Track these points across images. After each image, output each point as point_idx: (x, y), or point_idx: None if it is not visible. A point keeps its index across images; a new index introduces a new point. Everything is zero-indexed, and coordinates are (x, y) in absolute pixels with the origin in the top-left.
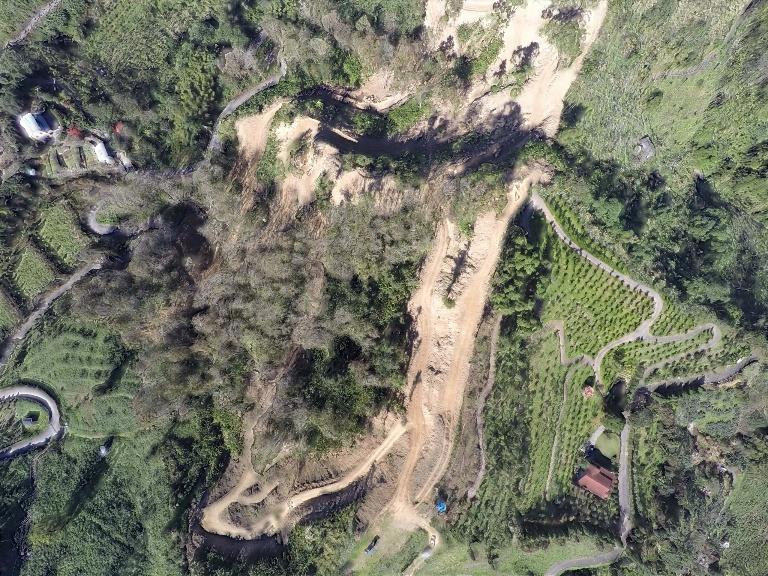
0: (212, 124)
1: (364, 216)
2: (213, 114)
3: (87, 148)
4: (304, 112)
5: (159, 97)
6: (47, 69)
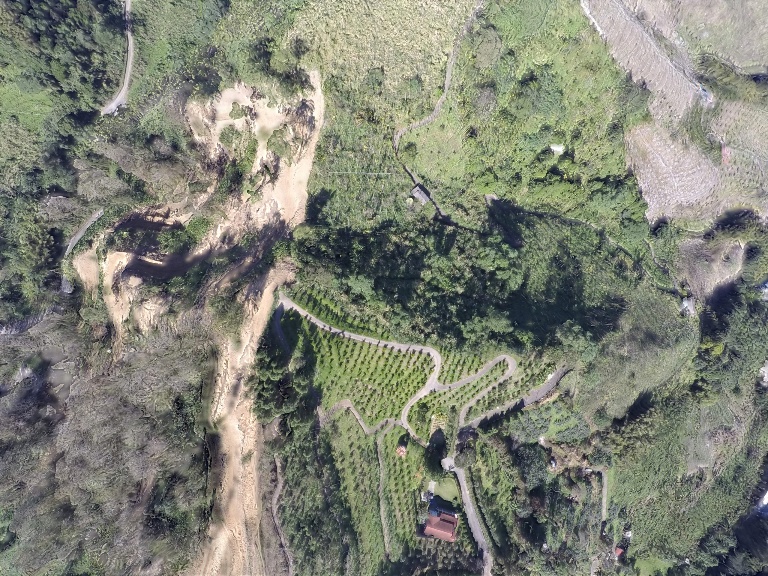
0: (59, 265)
1: (156, 347)
2: (58, 256)
3: None
4: (113, 246)
5: (6, 255)
6: None
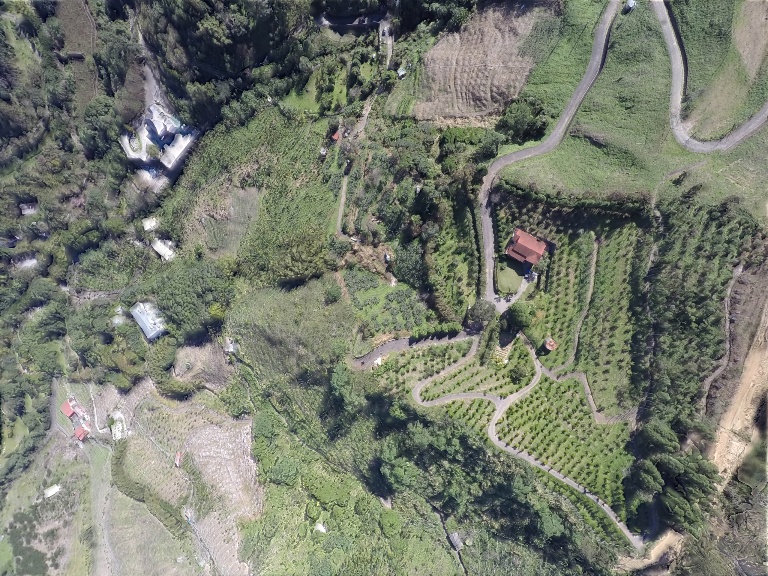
0: None
1: None
2: None
3: None
4: None
5: None
6: None
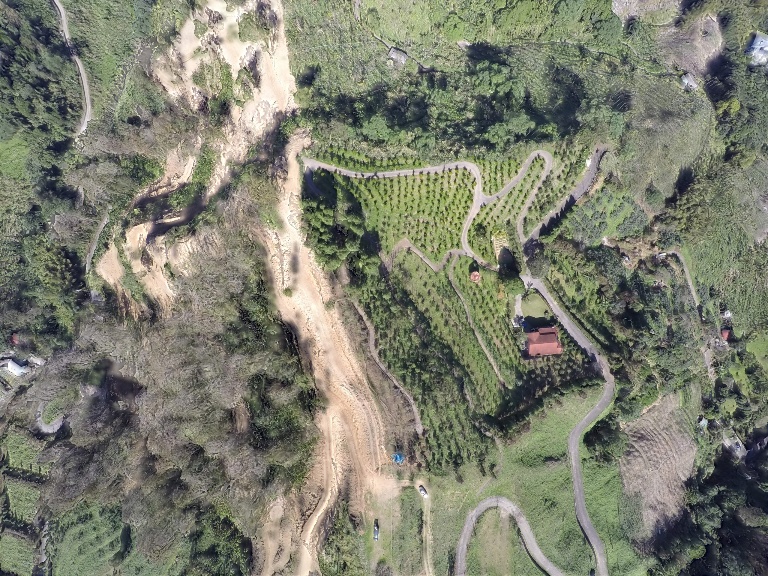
0: (84, 284)
1: None
2: (79, 276)
3: (3, 373)
4: (129, 225)
5: (31, 294)
6: None
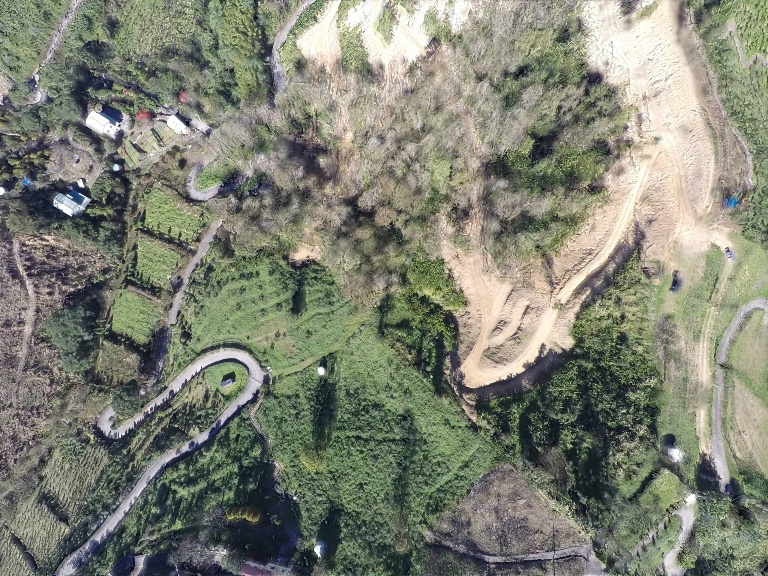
0: (269, 61)
1: None
2: (266, 51)
3: (158, 128)
4: None
5: (208, 55)
6: (87, 74)
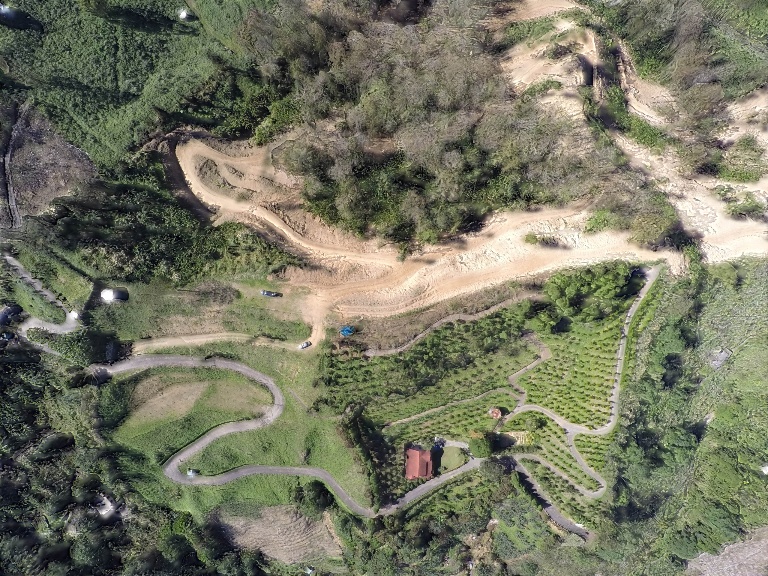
0: None
1: None
2: None
3: None
4: (595, 31)
5: None
6: None
